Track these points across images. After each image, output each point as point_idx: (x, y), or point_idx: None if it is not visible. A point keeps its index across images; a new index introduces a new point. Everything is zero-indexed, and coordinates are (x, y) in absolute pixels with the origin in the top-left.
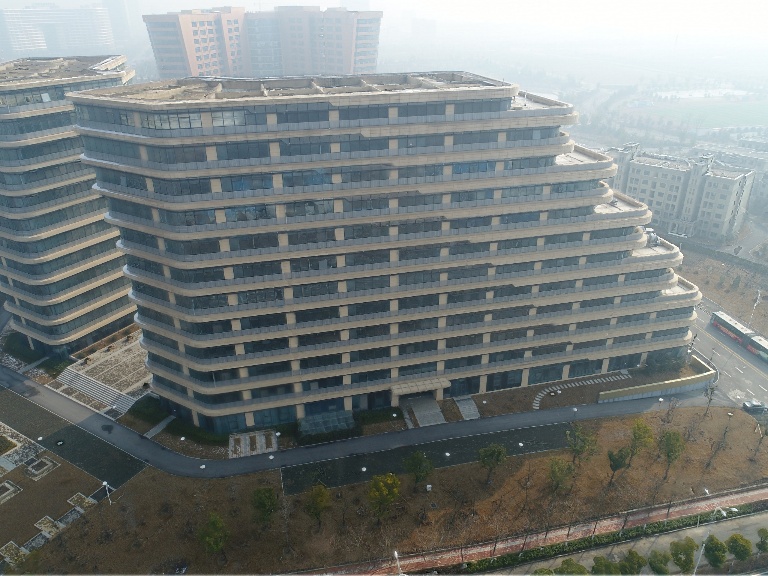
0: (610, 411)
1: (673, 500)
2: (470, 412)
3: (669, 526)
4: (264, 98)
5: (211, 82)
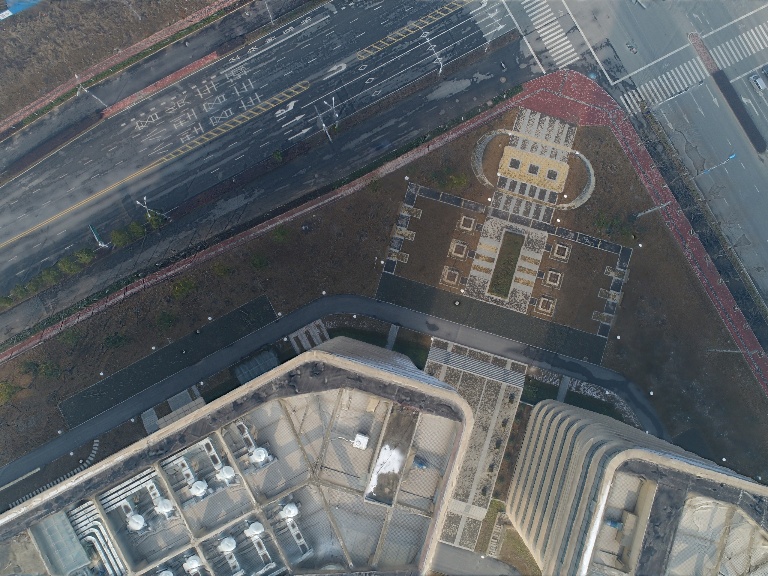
0: (36, 456)
1: (6, 363)
2: (149, 418)
3: (13, 339)
4: (210, 406)
5: (367, 571)
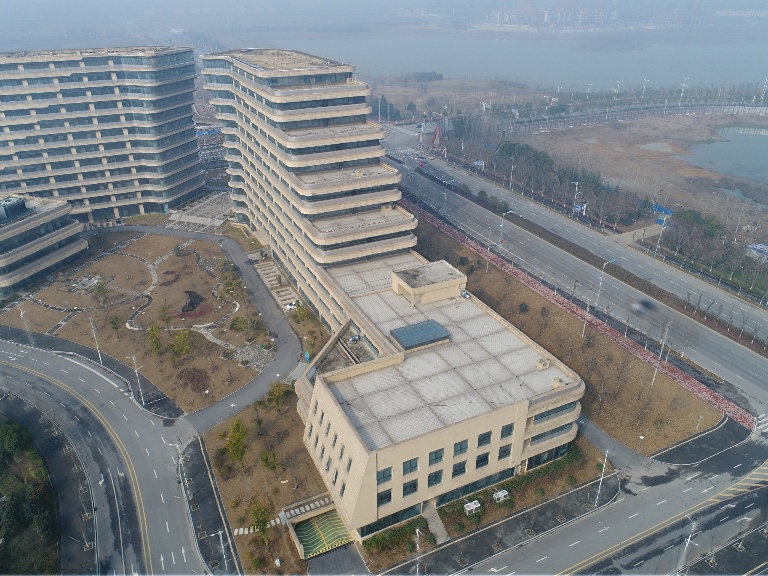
0: None
1: None
2: None
3: None
4: None
5: None
